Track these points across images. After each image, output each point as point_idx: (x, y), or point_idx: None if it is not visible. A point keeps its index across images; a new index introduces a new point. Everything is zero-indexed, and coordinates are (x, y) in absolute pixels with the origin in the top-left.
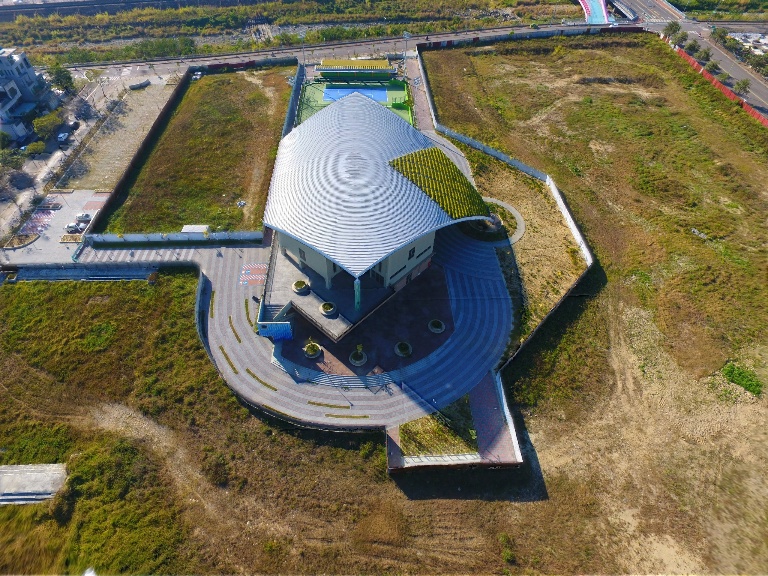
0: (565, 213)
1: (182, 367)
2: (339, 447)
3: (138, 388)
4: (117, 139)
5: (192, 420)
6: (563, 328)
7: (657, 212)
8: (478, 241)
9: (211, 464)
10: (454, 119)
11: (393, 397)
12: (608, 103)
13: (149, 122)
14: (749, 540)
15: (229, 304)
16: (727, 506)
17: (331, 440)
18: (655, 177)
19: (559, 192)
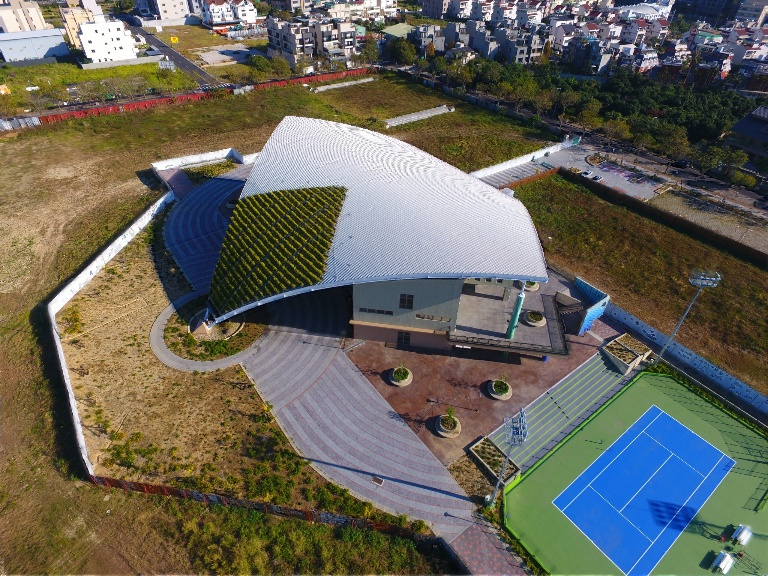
0: None
1: None
2: None
3: None
4: None
5: None
6: (109, 240)
7: None
8: None
9: None
10: None
11: None
12: None
13: None
14: (2, 190)
15: None
16: (7, 197)
17: None
18: None
19: (68, 453)
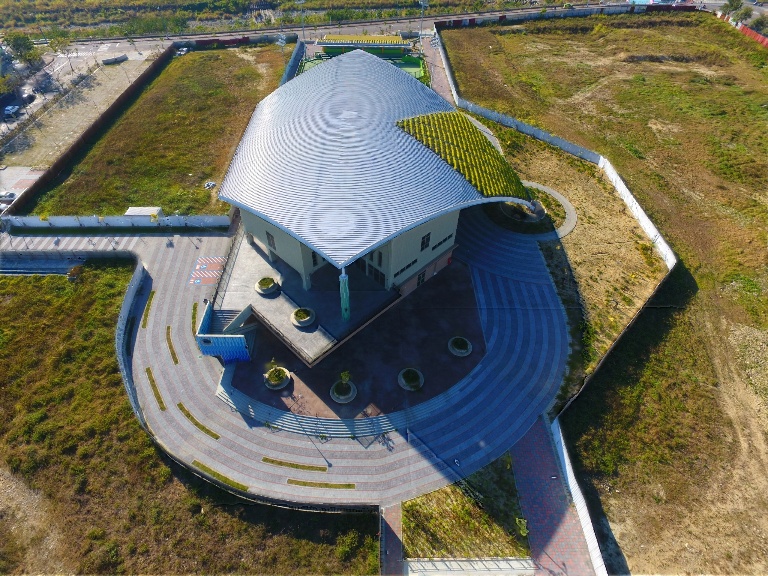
0: (629, 200)
1: (85, 398)
2: (304, 538)
3: (13, 429)
4: (75, 113)
5: (81, 484)
6: (645, 353)
7: (751, 201)
8: (515, 233)
9: (93, 564)
10: (479, 95)
11: (393, 454)
12: (665, 81)
13: (117, 96)
14: None
15: (171, 309)
16: None
17: (291, 526)
18: (739, 160)
19: None
